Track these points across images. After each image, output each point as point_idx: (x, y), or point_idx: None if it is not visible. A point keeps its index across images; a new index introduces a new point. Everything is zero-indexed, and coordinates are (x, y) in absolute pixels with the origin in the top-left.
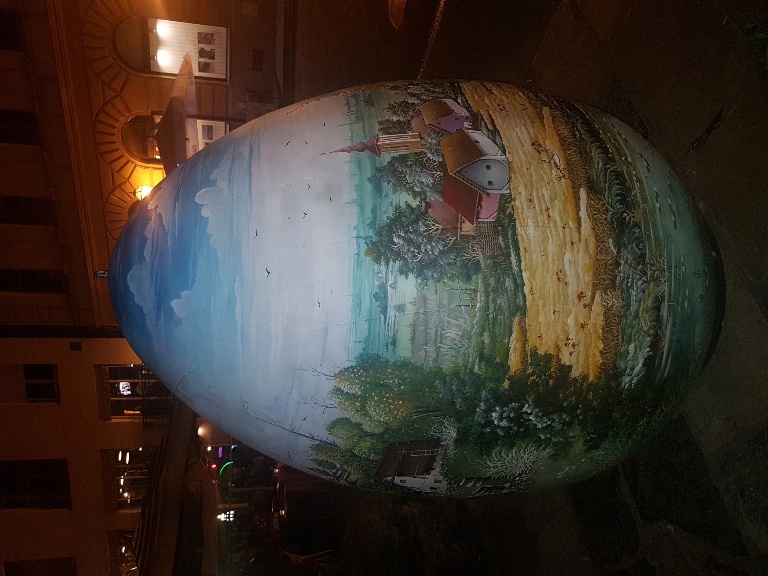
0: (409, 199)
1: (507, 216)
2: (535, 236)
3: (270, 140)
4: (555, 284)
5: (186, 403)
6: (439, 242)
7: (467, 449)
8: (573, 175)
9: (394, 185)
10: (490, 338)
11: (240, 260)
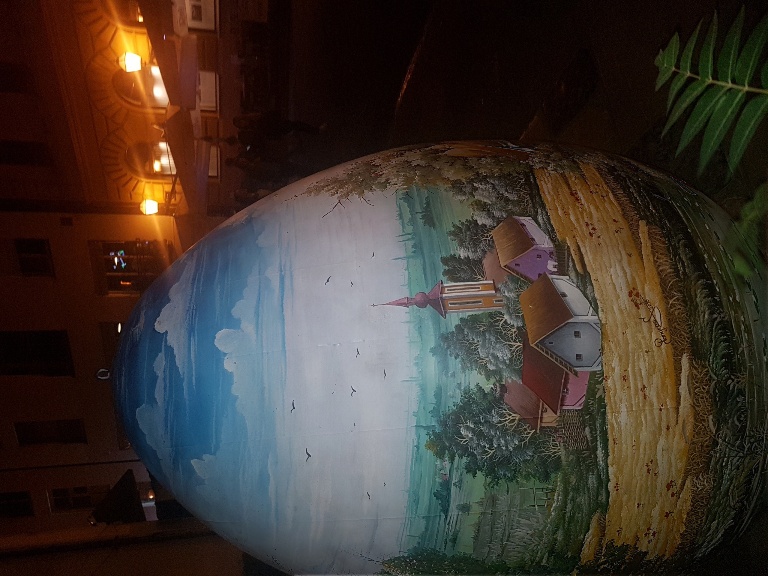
0: (481, 380)
1: (597, 401)
2: (627, 424)
3: (305, 267)
4: (644, 477)
5: None
6: (515, 436)
7: None
8: (675, 337)
9: (463, 360)
10: (564, 535)
11: (274, 435)
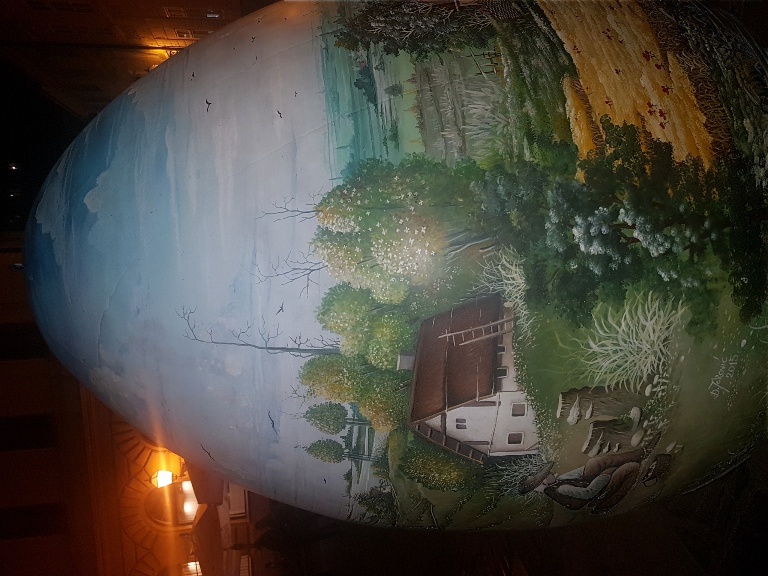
0: None
1: None
2: (559, 1)
3: None
4: (606, 42)
5: (117, 391)
6: (432, 16)
7: (549, 313)
8: None
9: None
10: (535, 108)
11: (172, 106)
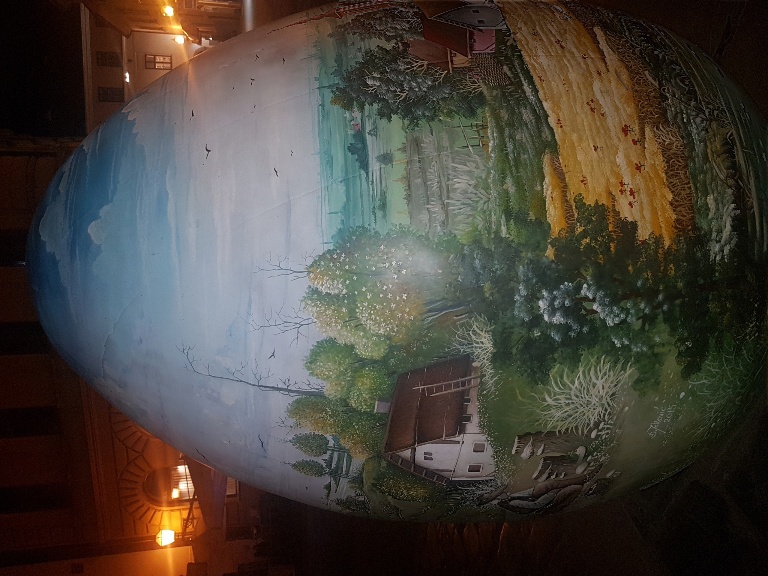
0: (381, 43)
1: (509, 47)
2: (549, 65)
3: None
4: (588, 115)
5: (119, 398)
6: (426, 78)
7: (512, 372)
8: (581, 17)
9: (361, 34)
10: (515, 186)
11: (172, 147)
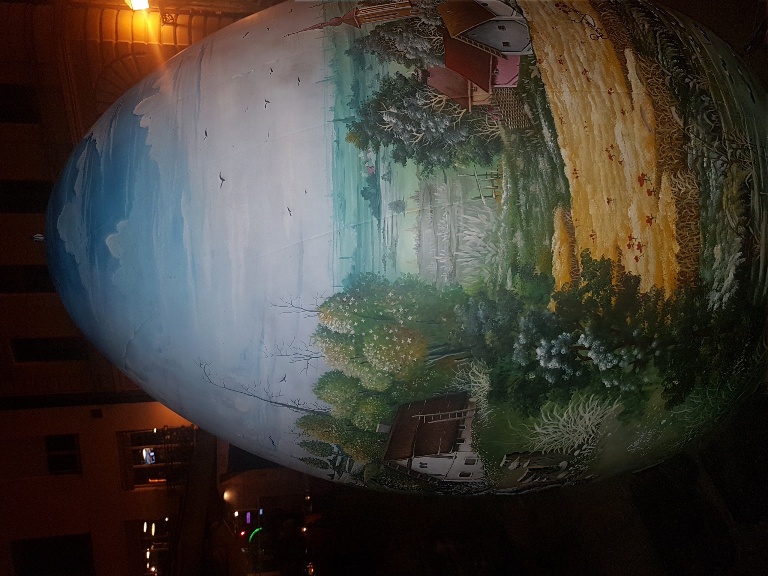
0: (401, 68)
1: (532, 80)
2: (572, 103)
3: (226, 37)
4: (606, 163)
5: (141, 386)
6: (444, 116)
7: (506, 407)
8: (613, 35)
9: (380, 55)
10: (524, 240)
11: (186, 170)
